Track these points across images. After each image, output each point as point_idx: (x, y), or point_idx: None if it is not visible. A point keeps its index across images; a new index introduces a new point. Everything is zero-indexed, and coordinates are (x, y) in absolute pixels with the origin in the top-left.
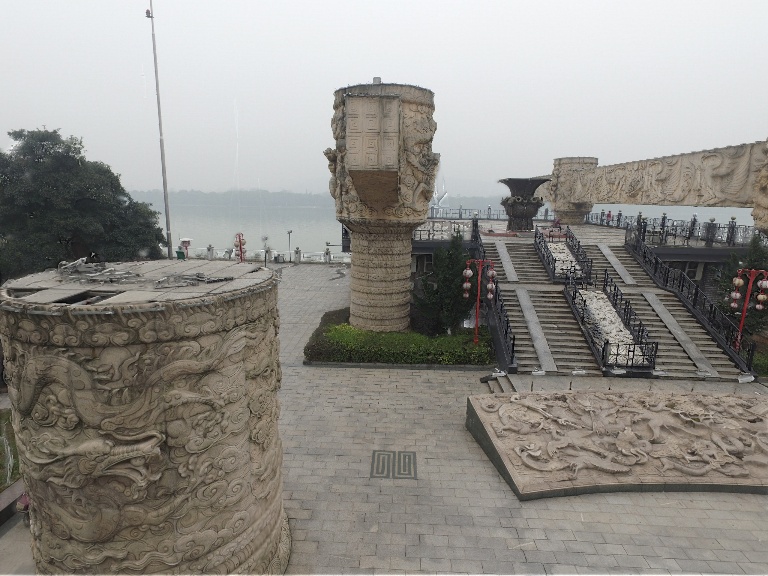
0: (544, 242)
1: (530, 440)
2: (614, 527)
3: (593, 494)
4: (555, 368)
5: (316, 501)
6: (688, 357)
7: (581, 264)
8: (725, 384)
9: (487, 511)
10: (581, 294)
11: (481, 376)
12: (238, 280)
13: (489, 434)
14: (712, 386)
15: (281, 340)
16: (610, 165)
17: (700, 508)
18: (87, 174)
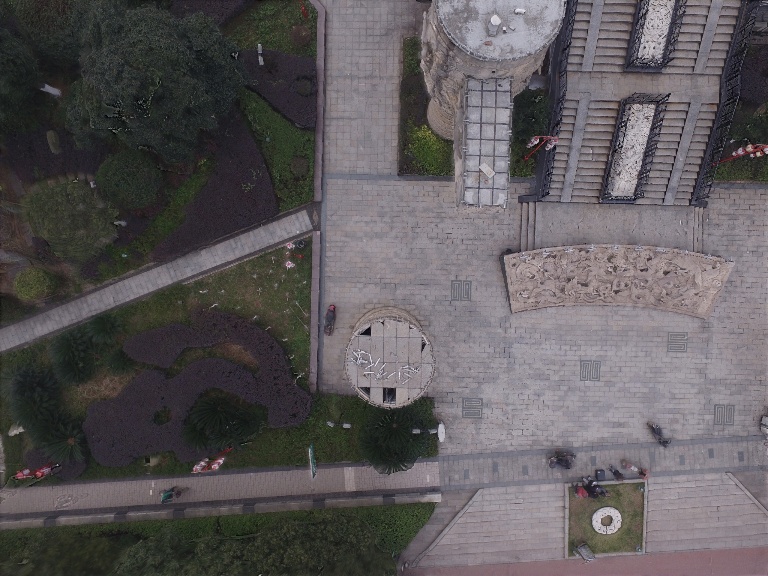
0: (646, 11)
1: (526, 285)
2: (542, 326)
3: (543, 308)
4: (569, 199)
5: (430, 316)
6: (667, 185)
7: (669, 38)
8: (671, 209)
9: (497, 320)
10: (634, 110)
11: (520, 192)
12: (423, 367)
13: (508, 283)
14: (660, 213)
15: (370, 126)
16: None
17: (581, 315)
18: (180, 93)
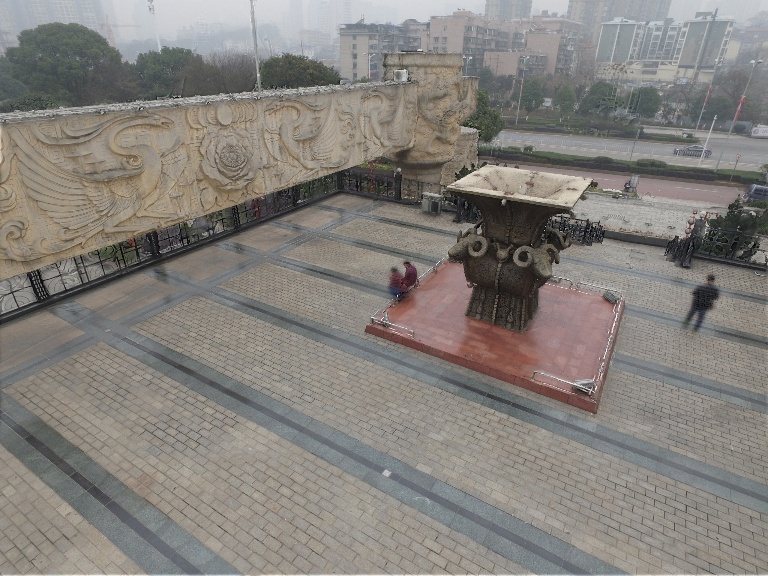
0: None
1: None
2: None
3: None
4: None
5: None
6: None
7: None
8: None
9: None
10: None
11: None
12: None
13: None
14: None
15: None
16: (65, 115)
17: None
18: None
